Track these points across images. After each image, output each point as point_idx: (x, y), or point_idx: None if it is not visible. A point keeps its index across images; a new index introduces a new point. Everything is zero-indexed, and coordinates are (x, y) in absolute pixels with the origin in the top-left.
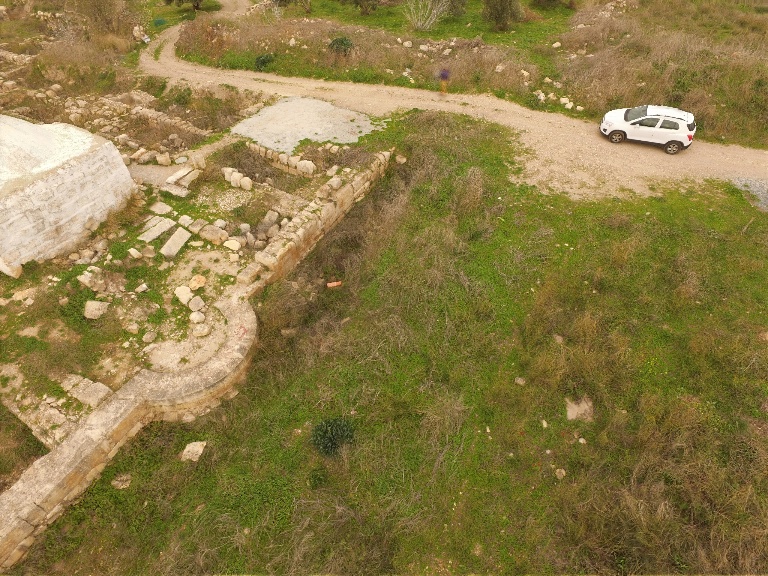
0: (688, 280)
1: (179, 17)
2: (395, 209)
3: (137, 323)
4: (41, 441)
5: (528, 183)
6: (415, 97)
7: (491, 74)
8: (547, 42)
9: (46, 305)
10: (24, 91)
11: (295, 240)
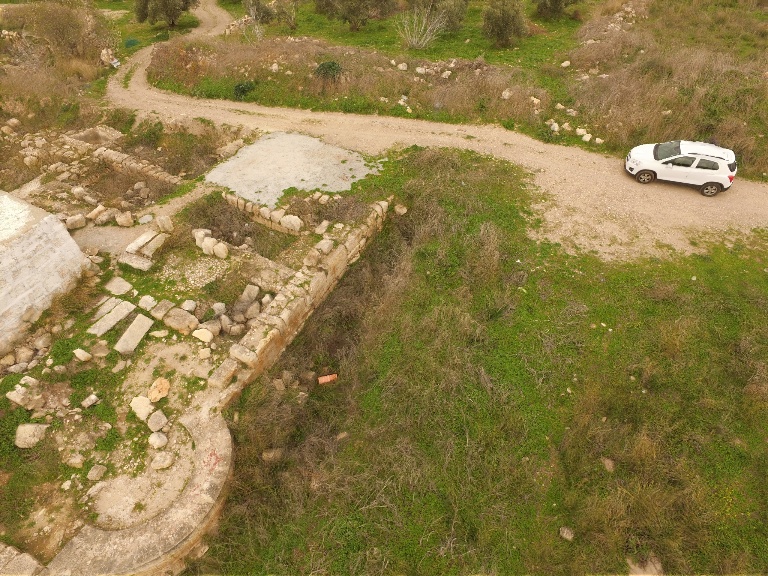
0: (757, 374)
1: (153, 36)
2: (397, 281)
3: (81, 454)
4: None
5: (550, 239)
6: (413, 130)
7: (497, 102)
8: (555, 60)
9: None
10: None
11: (279, 326)
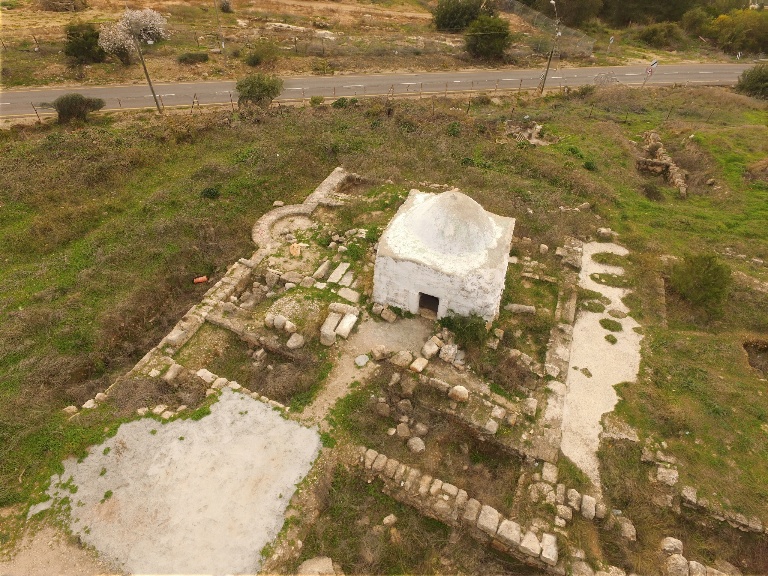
0: None
1: None
2: (122, 303)
3: None
4: None
5: None
6: None
7: None
8: None
9: None
10: None
11: None
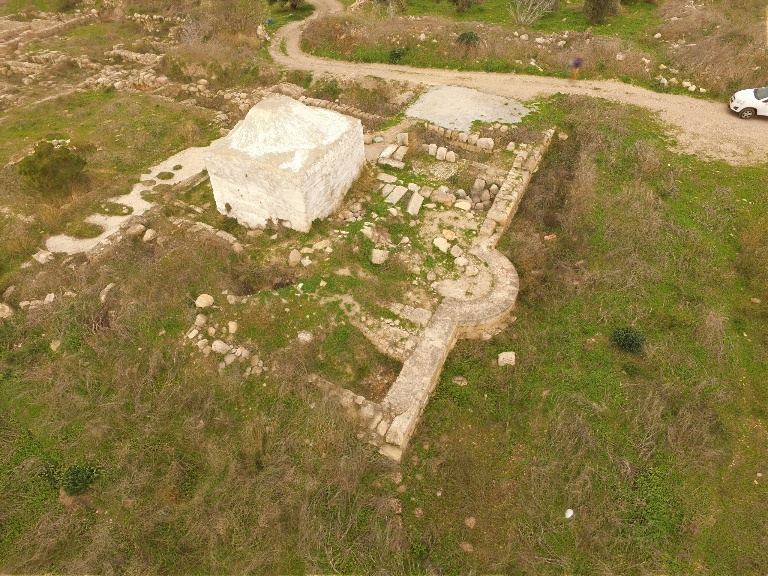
0: None
1: (285, 17)
2: (588, 175)
3: (418, 266)
4: (385, 353)
5: (687, 153)
6: (549, 84)
7: (616, 62)
8: (646, 33)
9: (344, 252)
10: (179, 85)
11: (514, 201)
